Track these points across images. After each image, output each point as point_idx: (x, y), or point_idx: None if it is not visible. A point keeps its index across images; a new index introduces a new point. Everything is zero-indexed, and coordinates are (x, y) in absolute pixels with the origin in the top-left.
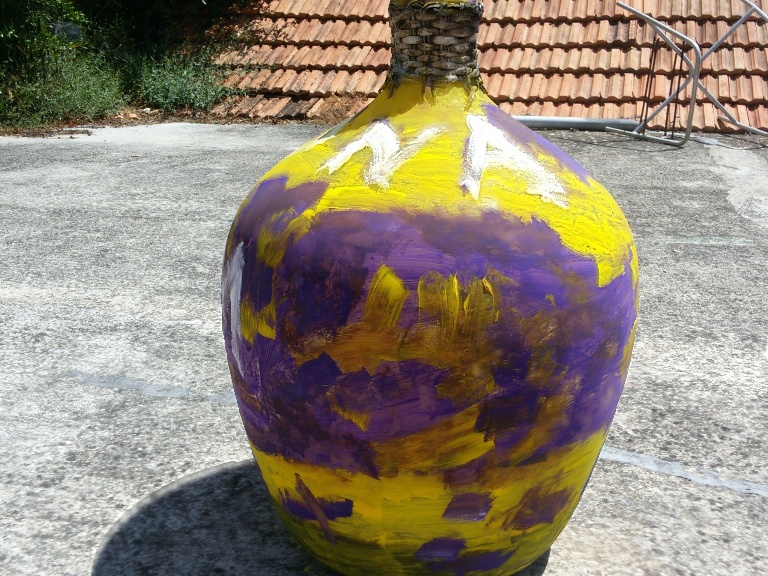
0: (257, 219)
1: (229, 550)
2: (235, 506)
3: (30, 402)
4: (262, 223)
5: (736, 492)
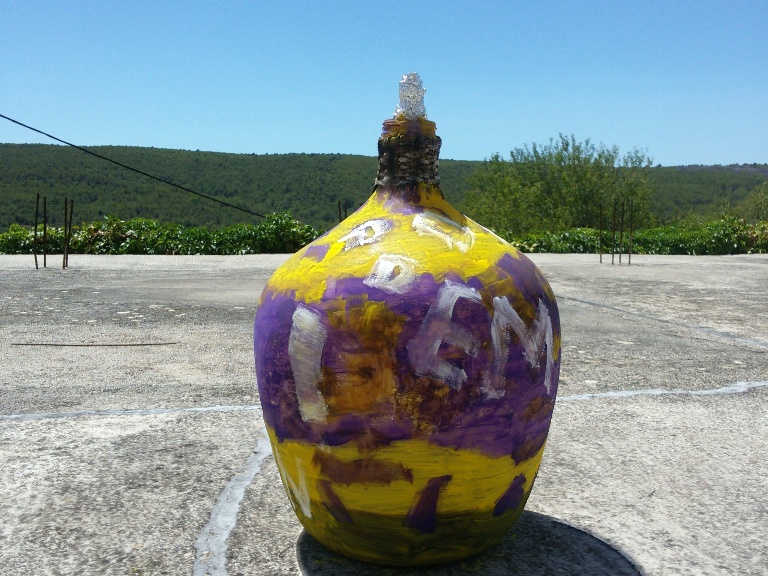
0: (534, 281)
1: None
2: None
3: None
4: (539, 281)
5: None
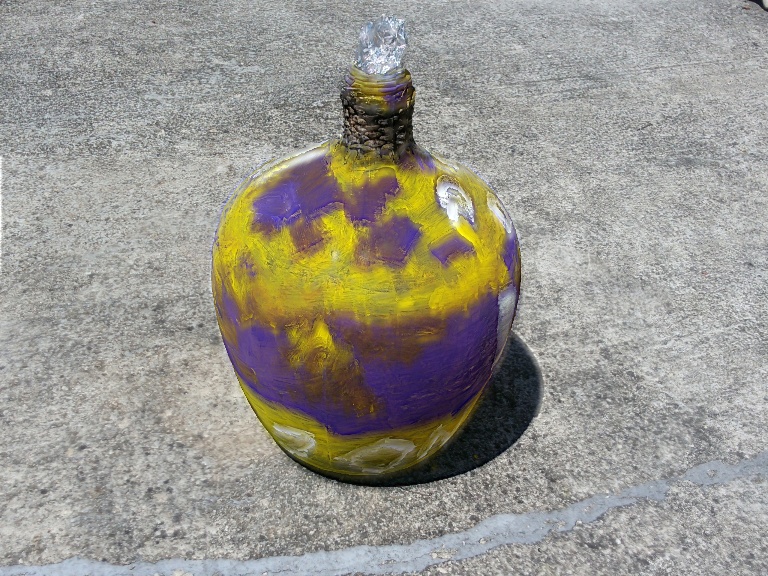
0: None
1: None
2: None
3: (761, 407)
4: None
5: (144, 560)
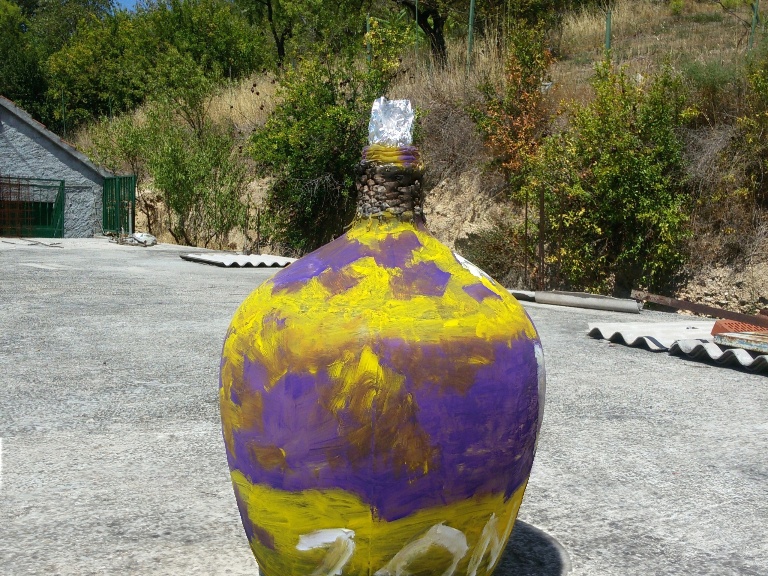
0: None
1: None
2: None
3: None
4: None
5: None
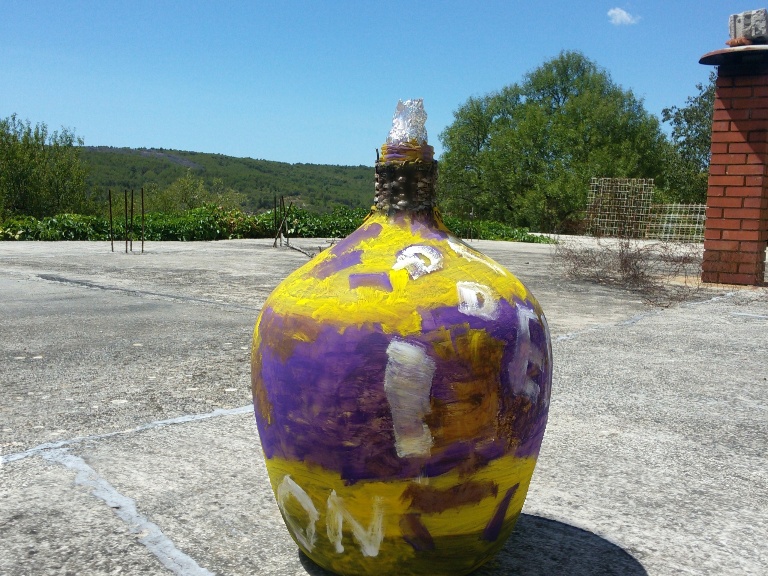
0: None
1: (546, 569)
2: None
3: None
4: None
5: None
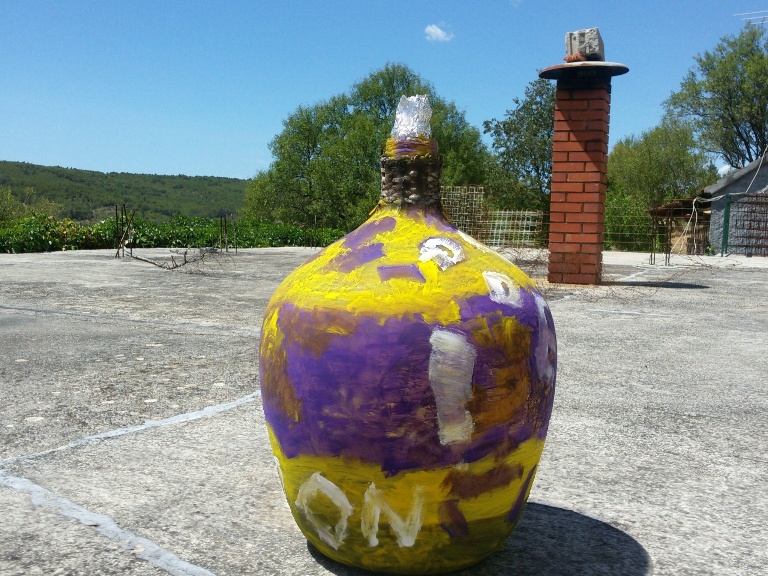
0: None
1: None
2: (555, 572)
3: None
4: None
5: None
